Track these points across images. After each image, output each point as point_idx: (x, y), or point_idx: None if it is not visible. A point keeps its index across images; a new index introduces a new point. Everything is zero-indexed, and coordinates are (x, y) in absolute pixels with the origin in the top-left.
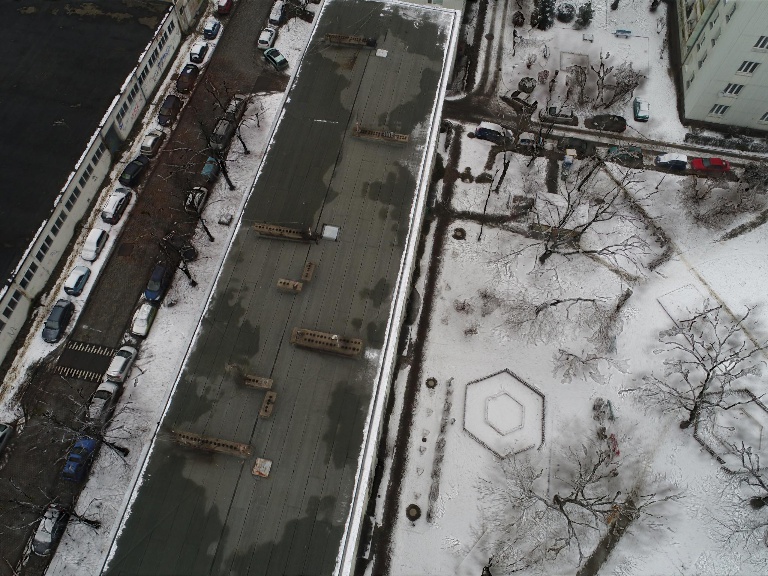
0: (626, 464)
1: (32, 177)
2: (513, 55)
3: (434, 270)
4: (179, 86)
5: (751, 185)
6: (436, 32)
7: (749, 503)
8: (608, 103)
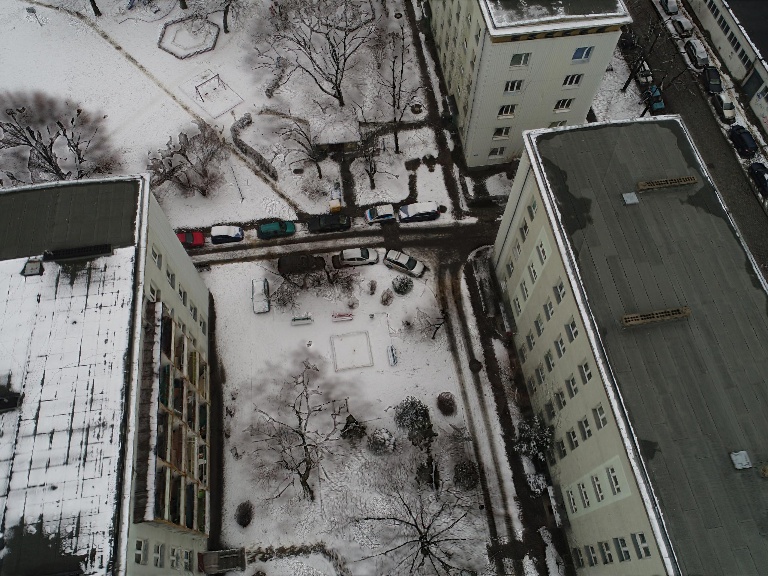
0: (264, 7)
1: (762, 11)
2: (434, 337)
3: (426, 78)
4: (761, 165)
5: (153, 191)
6: (502, 2)
7: (188, 7)
8: (301, 295)
